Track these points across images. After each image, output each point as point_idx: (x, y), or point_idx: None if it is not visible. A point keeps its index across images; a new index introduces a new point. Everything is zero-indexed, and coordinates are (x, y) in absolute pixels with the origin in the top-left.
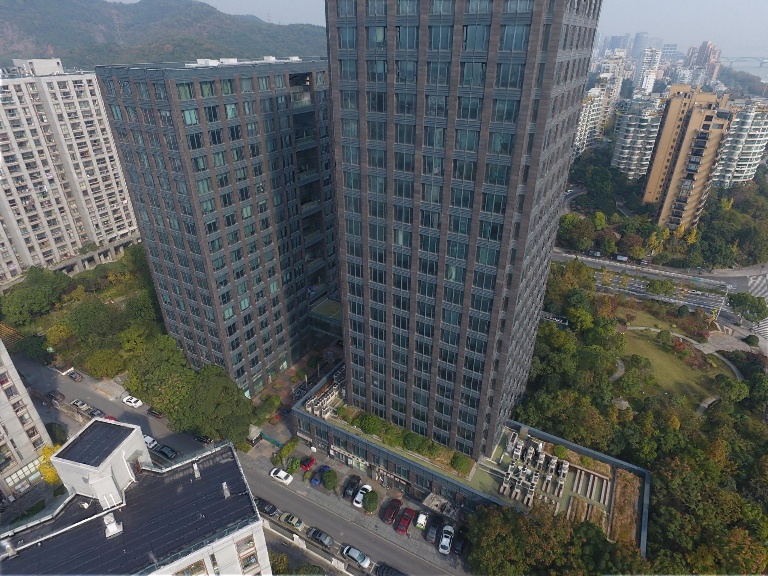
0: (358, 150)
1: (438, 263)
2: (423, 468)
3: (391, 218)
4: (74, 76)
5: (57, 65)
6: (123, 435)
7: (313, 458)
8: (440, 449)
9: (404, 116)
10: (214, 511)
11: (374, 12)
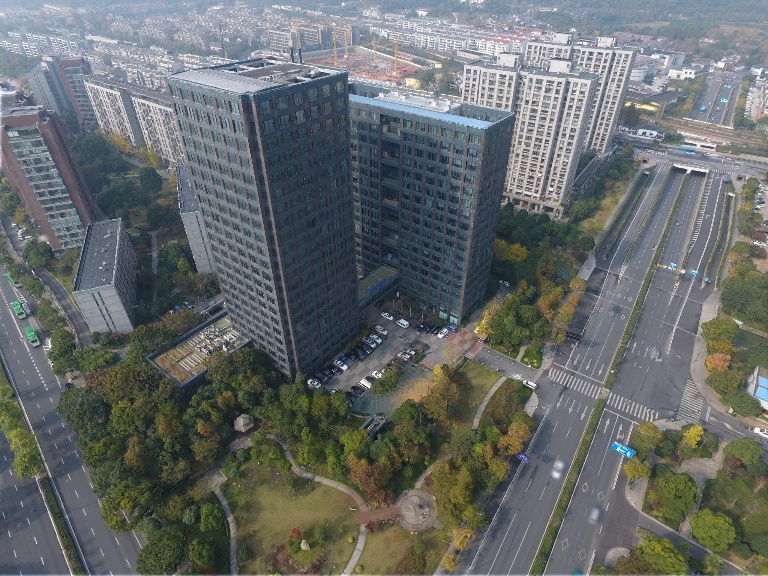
0: None
1: None
2: None
3: None
4: (551, 77)
5: (567, 66)
6: None
7: None
8: None
9: None
10: None
11: None
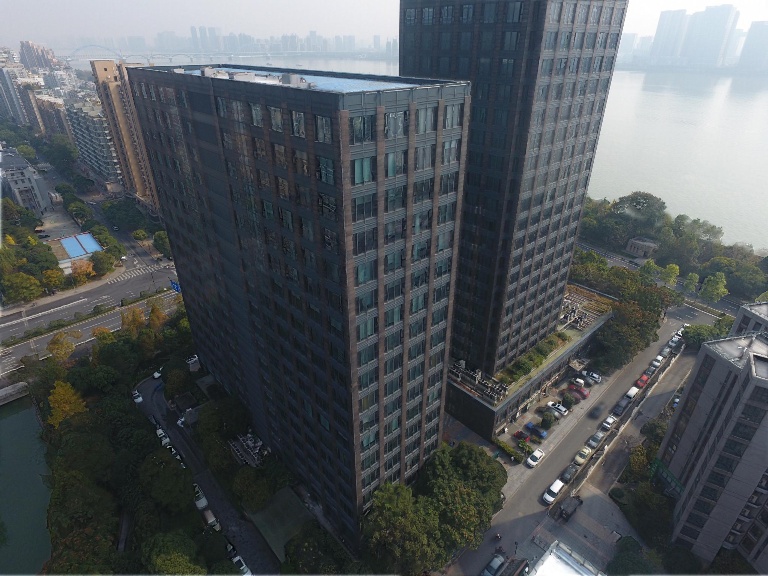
0: (540, 135)
1: (564, 202)
2: (568, 352)
3: (548, 183)
4: None
5: None
6: (759, 363)
7: (519, 431)
8: (552, 339)
9: (567, 99)
10: (764, 352)
11: (566, 20)
